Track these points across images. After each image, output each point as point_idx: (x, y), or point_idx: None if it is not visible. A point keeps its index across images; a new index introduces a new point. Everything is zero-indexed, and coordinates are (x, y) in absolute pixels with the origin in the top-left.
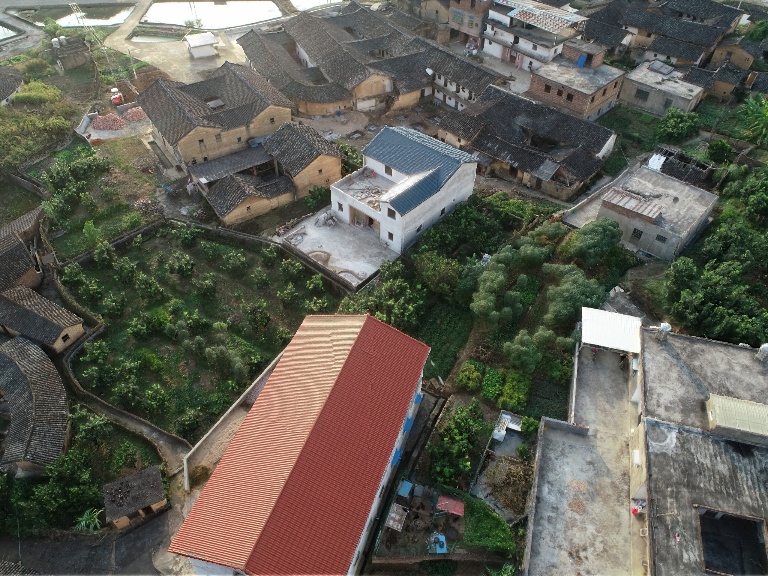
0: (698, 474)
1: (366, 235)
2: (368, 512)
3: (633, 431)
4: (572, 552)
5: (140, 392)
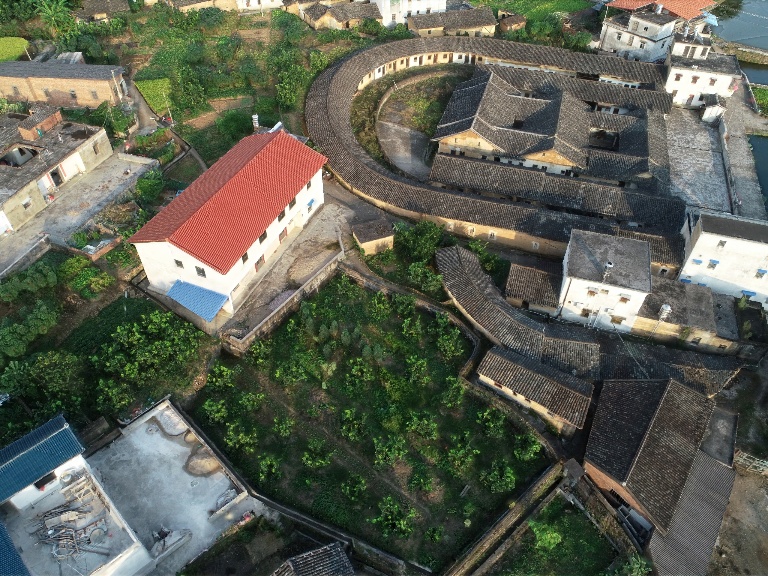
0: (0, 180)
1: (119, 506)
2: (214, 164)
3: (6, 234)
4: (106, 188)
5: (400, 322)
